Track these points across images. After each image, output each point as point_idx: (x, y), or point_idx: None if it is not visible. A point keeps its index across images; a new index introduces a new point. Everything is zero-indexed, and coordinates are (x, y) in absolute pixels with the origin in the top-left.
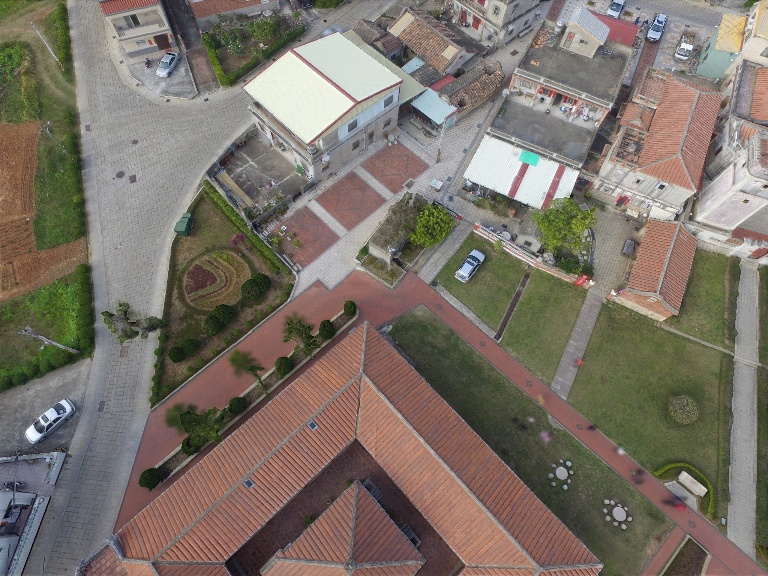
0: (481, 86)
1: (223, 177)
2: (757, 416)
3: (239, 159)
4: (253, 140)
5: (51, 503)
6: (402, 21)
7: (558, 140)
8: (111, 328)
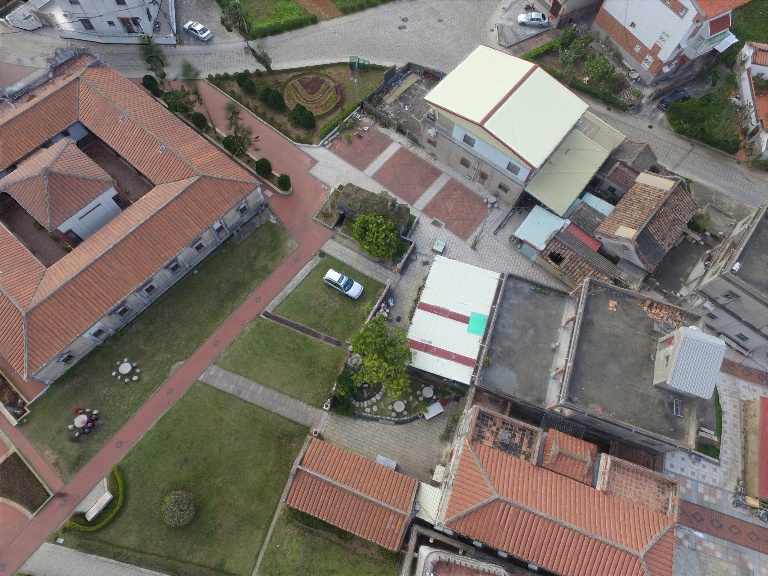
0: None
1: (413, 78)
2: None
3: None
4: None
5: (146, 46)
6: (660, 180)
7: (514, 358)
8: (225, 9)
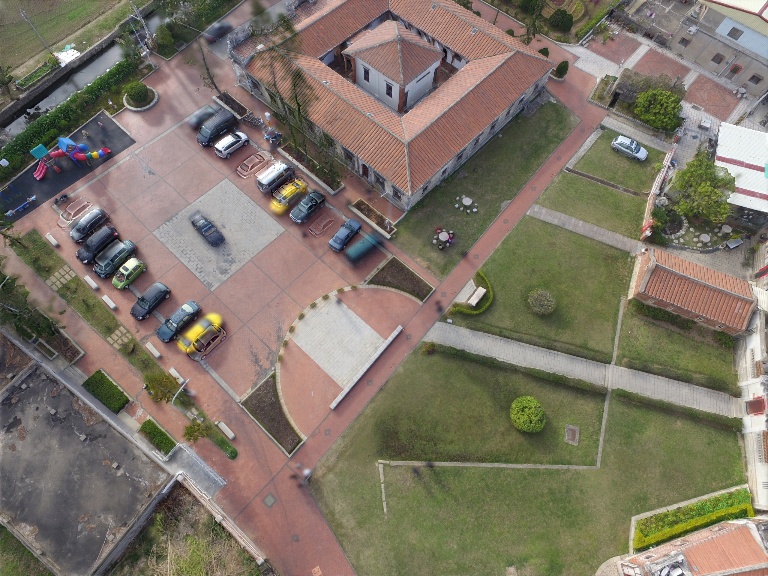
0: None
1: None
2: None
3: (668, 2)
4: (690, 7)
5: None
6: None
7: None
8: None
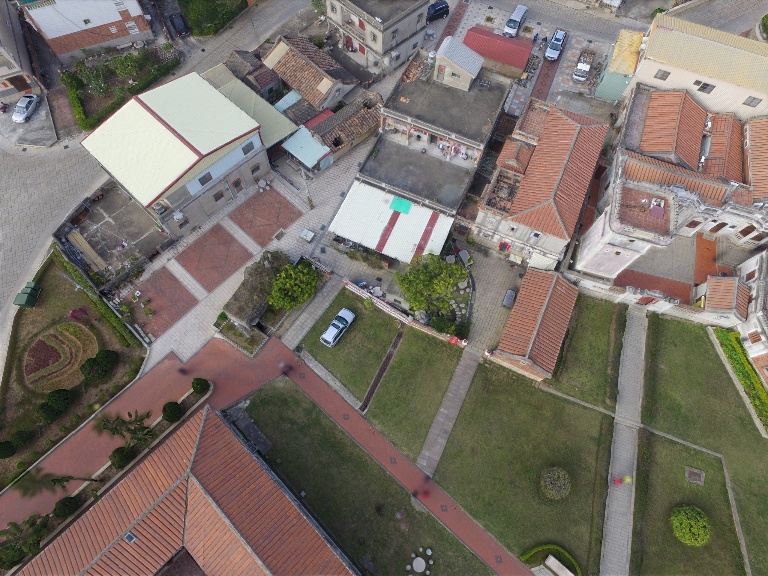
0: (359, 122)
1: (75, 237)
2: (635, 485)
3: (95, 215)
4: (112, 192)
5: None
6: (276, 51)
7: (433, 183)
8: None
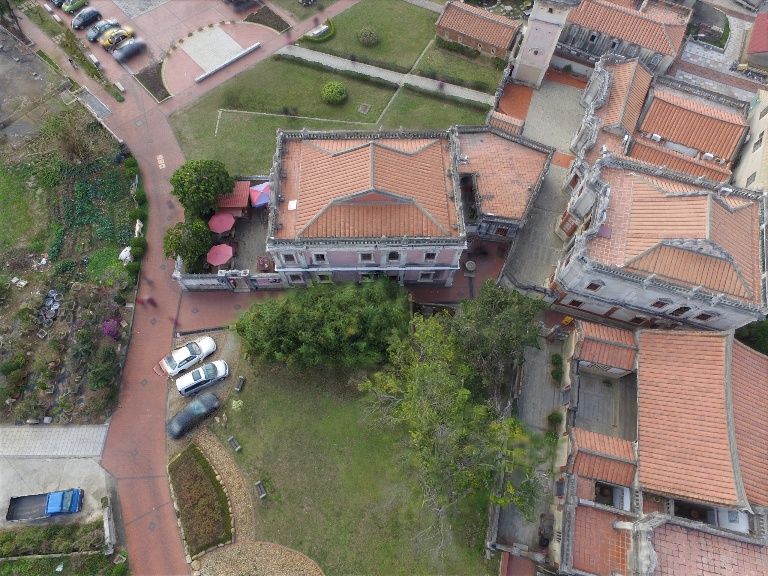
0: None
1: None
2: None
3: None
4: None
5: None
6: None
7: None
8: None
